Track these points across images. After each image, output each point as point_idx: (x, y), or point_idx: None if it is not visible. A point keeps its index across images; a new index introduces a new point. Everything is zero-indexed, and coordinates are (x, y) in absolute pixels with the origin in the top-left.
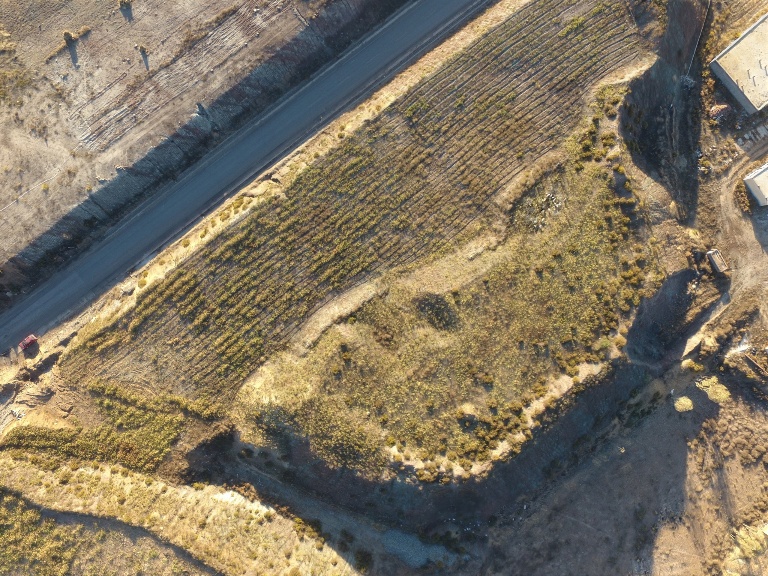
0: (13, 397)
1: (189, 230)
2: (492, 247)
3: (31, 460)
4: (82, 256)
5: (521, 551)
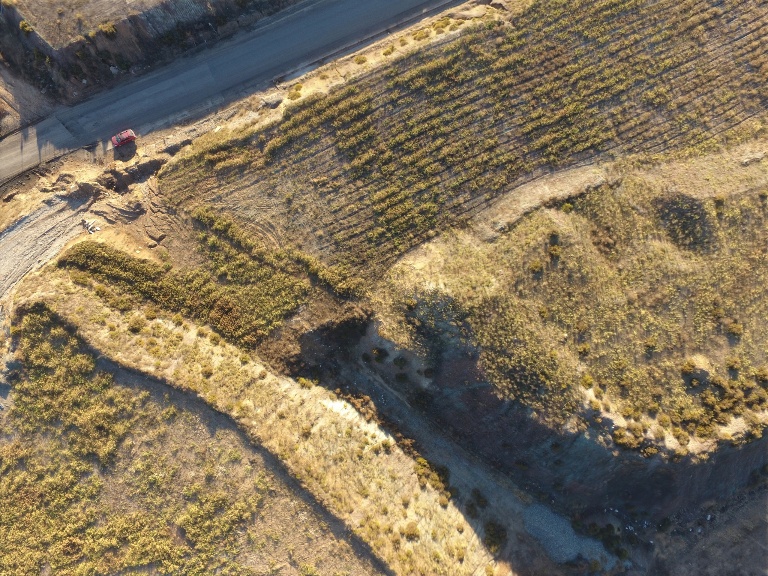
0: (89, 203)
1: (367, 45)
2: None
3: (96, 290)
4: (220, 45)
5: (690, 574)
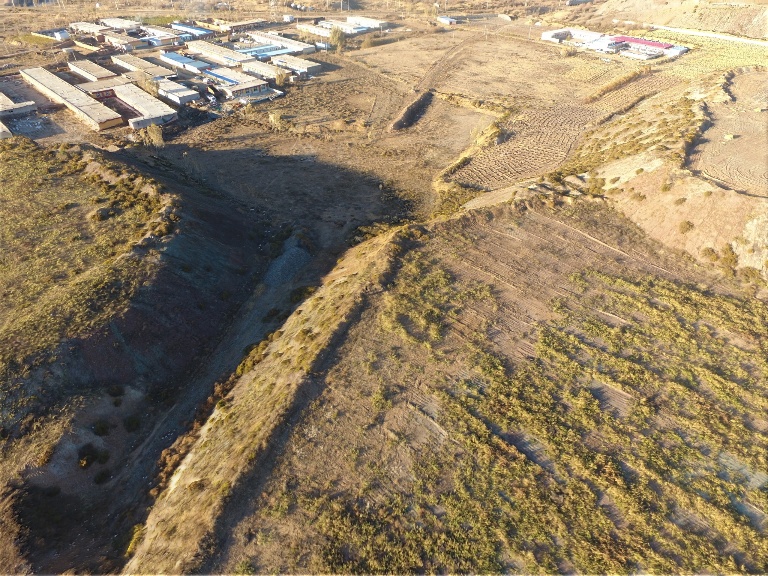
0: None
1: None
2: None
3: None
4: None
5: (297, 208)
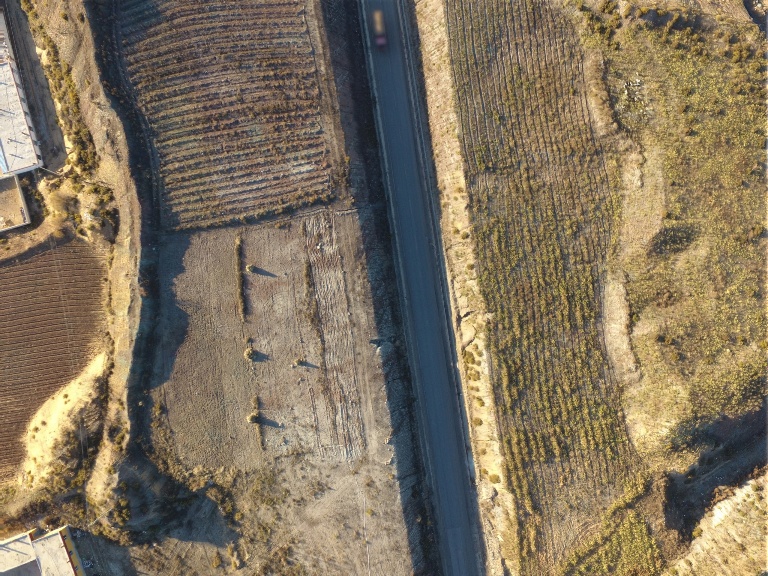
0: None
1: (466, 413)
2: (642, 161)
3: None
4: (437, 516)
5: None
